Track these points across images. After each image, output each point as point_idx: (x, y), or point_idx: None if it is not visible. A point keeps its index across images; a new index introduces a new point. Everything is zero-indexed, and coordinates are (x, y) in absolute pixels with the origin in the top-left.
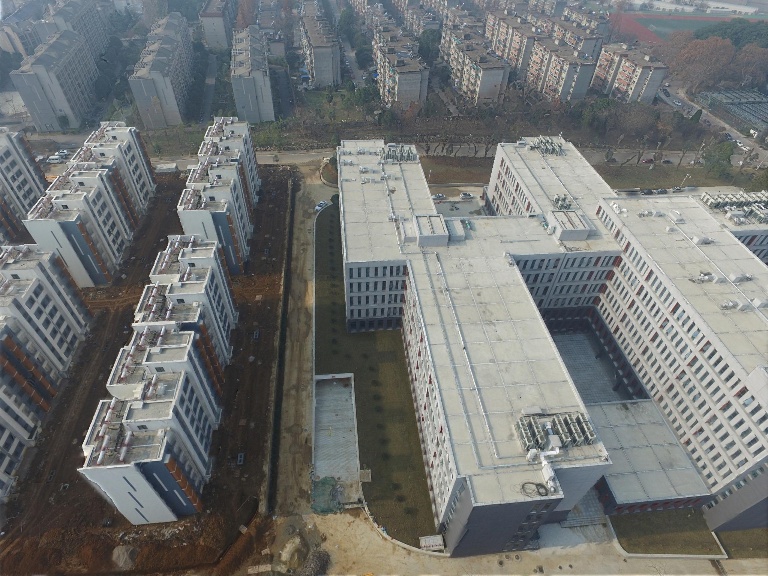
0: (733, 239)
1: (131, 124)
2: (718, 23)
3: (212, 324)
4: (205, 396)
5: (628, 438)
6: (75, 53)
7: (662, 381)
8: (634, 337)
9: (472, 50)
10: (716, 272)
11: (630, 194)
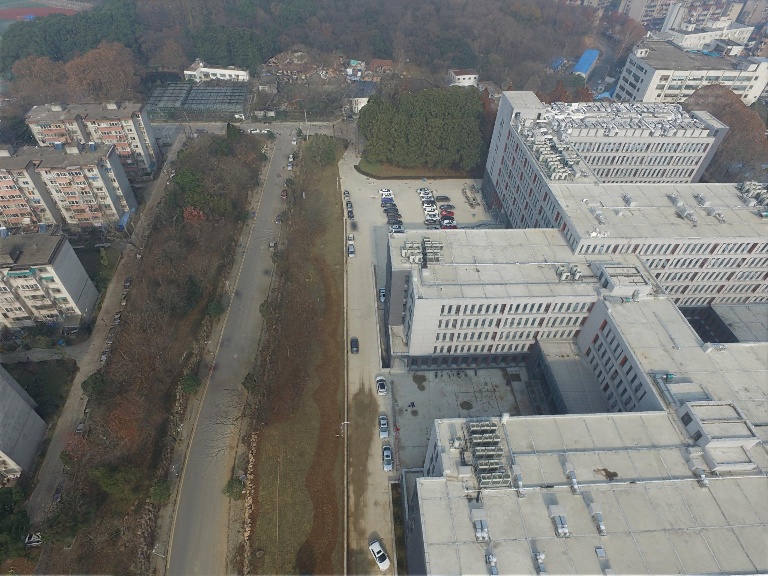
0: (613, 185)
1: None
2: (9, 36)
3: None
4: None
5: (763, 333)
6: None
7: (715, 291)
8: (672, 291)
9: None
10: (686, 209)
11: (356, 227)
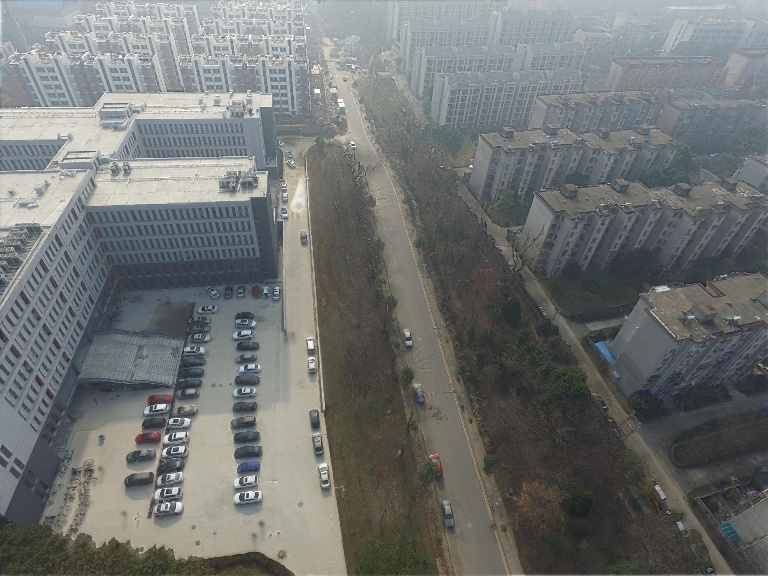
0: None
1: (409, 80)
2: None
3: (103, 82)
4: (66, 90)
5: None
6: (461, 32)
7: None
8: None
9: (618, 191)
10: None
11: (305, 386)
